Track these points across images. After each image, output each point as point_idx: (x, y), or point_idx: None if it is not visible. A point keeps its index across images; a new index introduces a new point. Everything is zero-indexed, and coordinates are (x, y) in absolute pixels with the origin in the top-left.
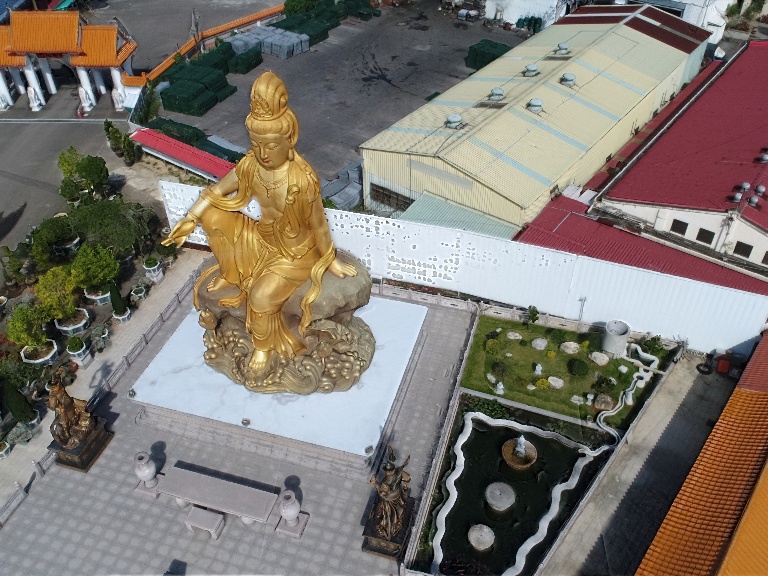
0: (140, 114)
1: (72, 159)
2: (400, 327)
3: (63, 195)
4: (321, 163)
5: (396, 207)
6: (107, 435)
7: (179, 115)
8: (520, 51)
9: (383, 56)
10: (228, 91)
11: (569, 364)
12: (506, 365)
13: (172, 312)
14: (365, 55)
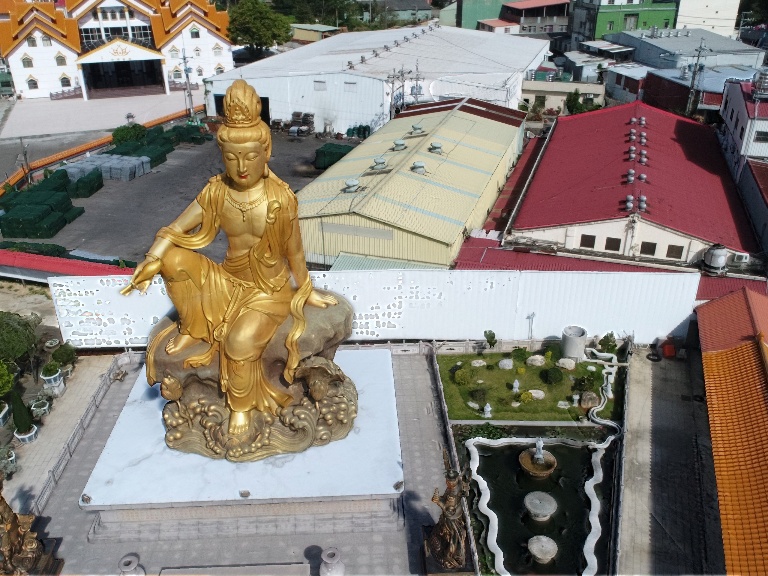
0: None
1: None
2: (371, 371)
3: None
4: None
5: None
6: (56, 563)
7: (24, 240)
8: (376, 138)
9: None
10: (76, 212)
11: (541, 376)
12: (484, 389)
13: (91, 419)
14: (212, 170)
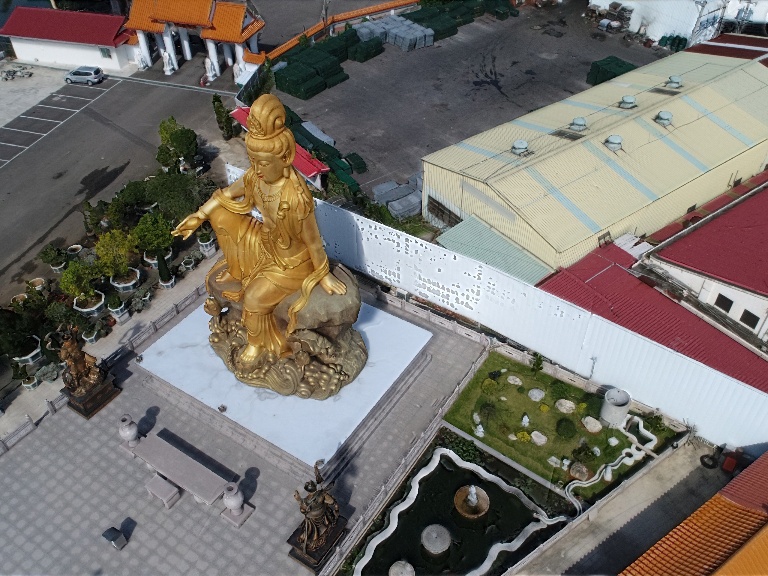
0: (251, 91)
1: (171, 128)
2: (398, 348)
3: (158, 160)
4: (400, 164)
5: (448, 224)
6: (115, 390)
7: (287, 96)
8: (631, 77)
9: (504, 60)
10: (339, 78)
11: (559, 423)
12: (494, 409)
13: None
14: (486, 57)
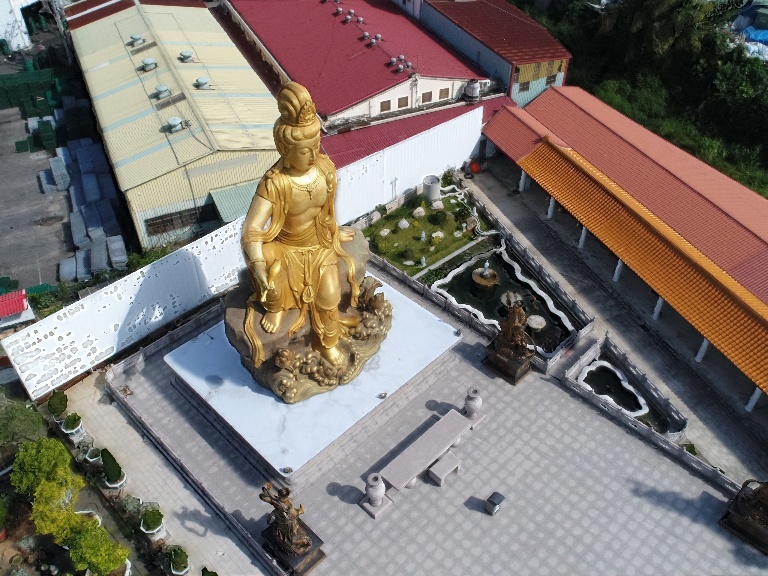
0: None
1: None
2: None
3: None
4: (28, 254)
5: (182, 226)
6: None
7: None
8: (93, 60)
9: None
10: None
11: (430, 221)
12: None
13: None
14: None
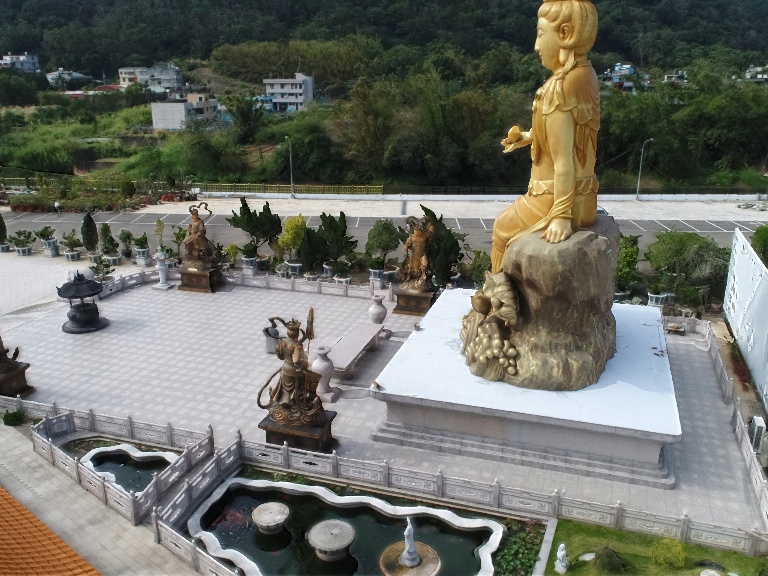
0: None
1: None
2: (614, 409)
3: None
4: None
5: None
6: None
7: None
8: None
9: None
10: None
11: None
12: (619, 563)
13: None
14: None
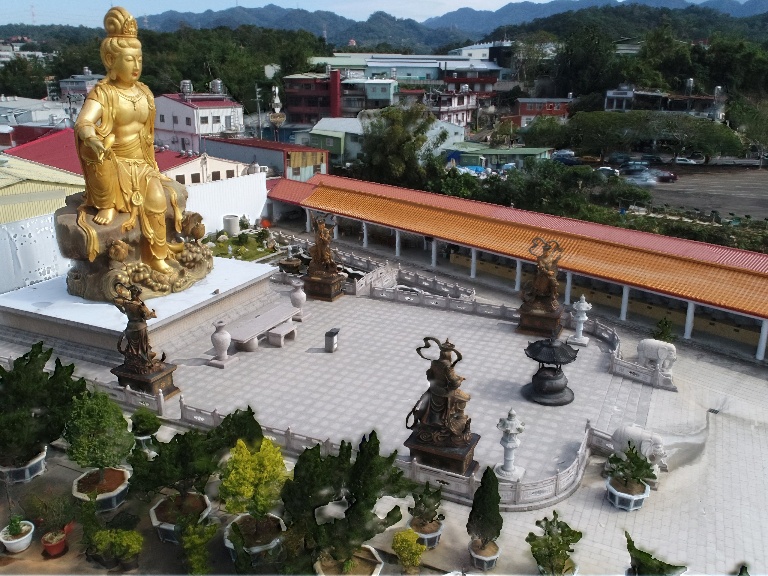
0: None
1: None
2: None
3: None
4: None
5: None
6: None
7: None
8: None
9: None
10: None
11: (234, 244)
12: None
13: None
14: None
